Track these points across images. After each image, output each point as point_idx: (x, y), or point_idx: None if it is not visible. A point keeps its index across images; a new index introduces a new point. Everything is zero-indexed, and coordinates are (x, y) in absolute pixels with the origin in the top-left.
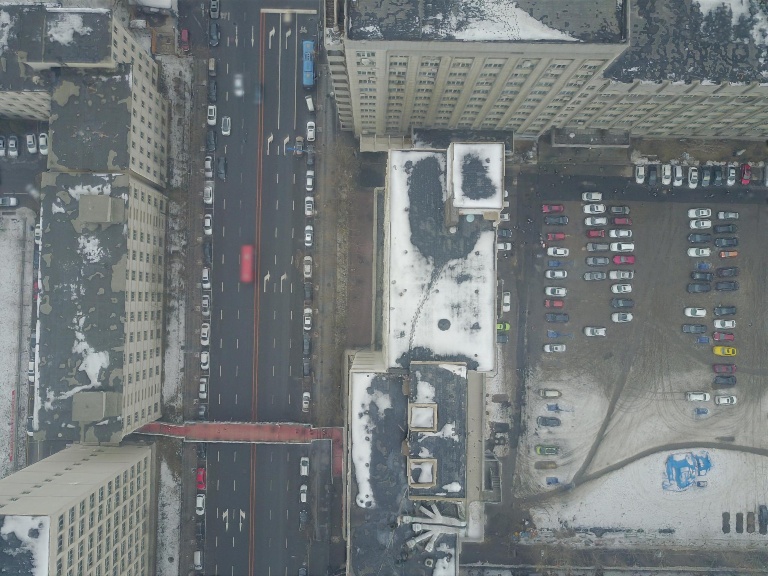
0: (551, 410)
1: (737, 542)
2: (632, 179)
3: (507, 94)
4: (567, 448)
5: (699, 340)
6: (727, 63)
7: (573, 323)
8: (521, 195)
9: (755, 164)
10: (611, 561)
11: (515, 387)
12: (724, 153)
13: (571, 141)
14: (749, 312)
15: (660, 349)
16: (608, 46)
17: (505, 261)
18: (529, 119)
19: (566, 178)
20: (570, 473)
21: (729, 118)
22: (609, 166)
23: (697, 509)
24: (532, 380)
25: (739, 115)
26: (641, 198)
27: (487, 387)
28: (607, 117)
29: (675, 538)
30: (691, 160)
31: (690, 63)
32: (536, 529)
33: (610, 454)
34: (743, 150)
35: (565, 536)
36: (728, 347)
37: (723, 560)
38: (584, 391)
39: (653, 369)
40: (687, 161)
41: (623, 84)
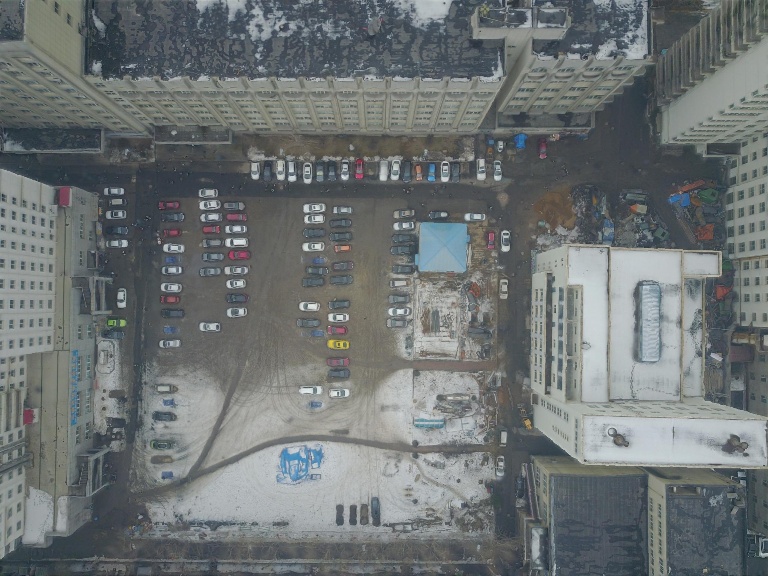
0: (167, 405)
1: (349, 534)
2: (249, 175)
3: (22, 93)
4: (183, 442)
5: (312, 334)
6: (224, 59)
7: (190, 319)
8: (139, 192)
9: (371, 159)
10: (227, 554)
11: (132, 383)
12: (340, 148)
13: (173, 138)
14: (364, 306)
15: (275, 343)
16: (7, 44)
17: (123, 258)
18: (99, 117)
19: (184, 175)
20: (186, 467)
21: (301, 113)
22: (227, 163)
23: (311, 502)
24: (149, 375)
25: (304, 110)
26: (258, 194)
27: (104, 383)
28: (182, 114)
29: (288, 531)
30: (307, 156)
31: (187, 59)
32: (151, 523)
33: (226, 448)
34: (350, 145)
35: (178, 530)
36: (340, 340)
37: (336, 552)
38: (200, 386)
39: (268, 363)
40: (303, 157)
41: (115, 81)
